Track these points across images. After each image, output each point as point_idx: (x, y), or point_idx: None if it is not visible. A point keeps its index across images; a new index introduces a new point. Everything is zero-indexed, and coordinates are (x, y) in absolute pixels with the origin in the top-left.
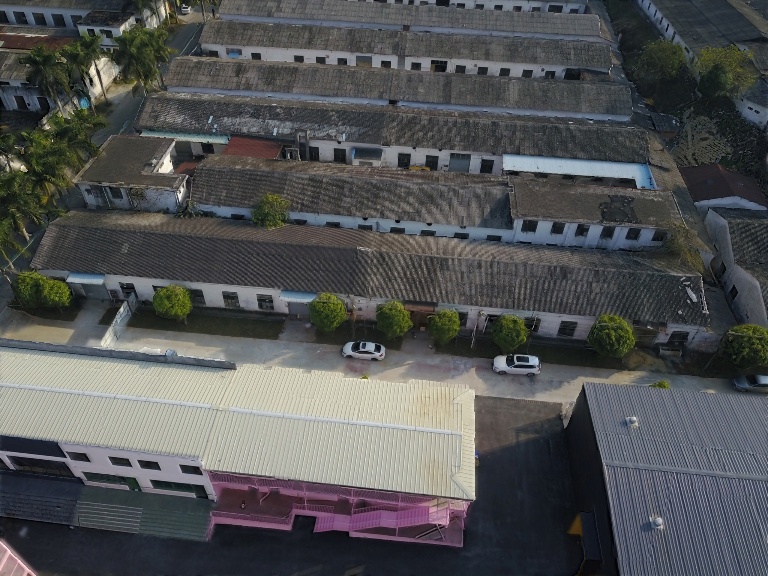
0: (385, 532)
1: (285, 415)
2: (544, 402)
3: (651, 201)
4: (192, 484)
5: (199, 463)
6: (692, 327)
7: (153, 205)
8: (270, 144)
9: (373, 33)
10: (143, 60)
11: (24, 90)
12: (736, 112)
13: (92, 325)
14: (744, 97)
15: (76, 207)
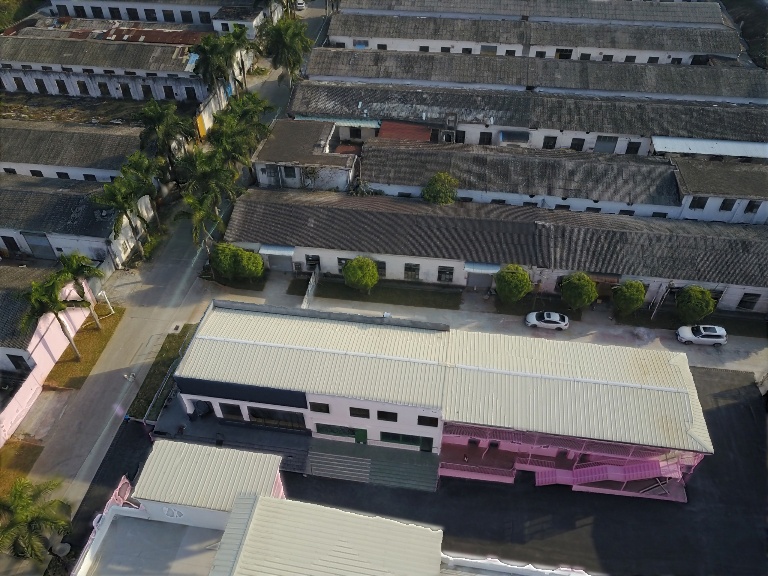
0: (610, 486)
1: (511, 372)
2: (735, 371)
3: None
4: (422, 436)
5: (440, 414)
6: None
7: (326, 183)
8: (420, 128)
9: (497, 23)
10: (295, 49)
11: (174, 80)
12: None
13: (281, 295)
14: None
15: (251, 186)
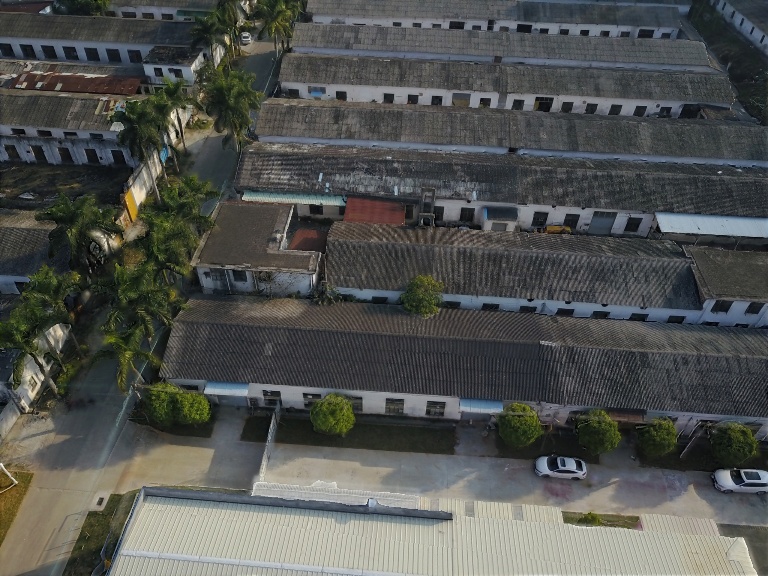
0: None
1: None
2: None
3: None
4: None
5: None
6: None
7: (284, 289)
8: (392, 205)
9: (469, 67)
10: (241, 111)
11: (97, 143)
12: None
13: (234, 442)
14: None
15: (193, 293)
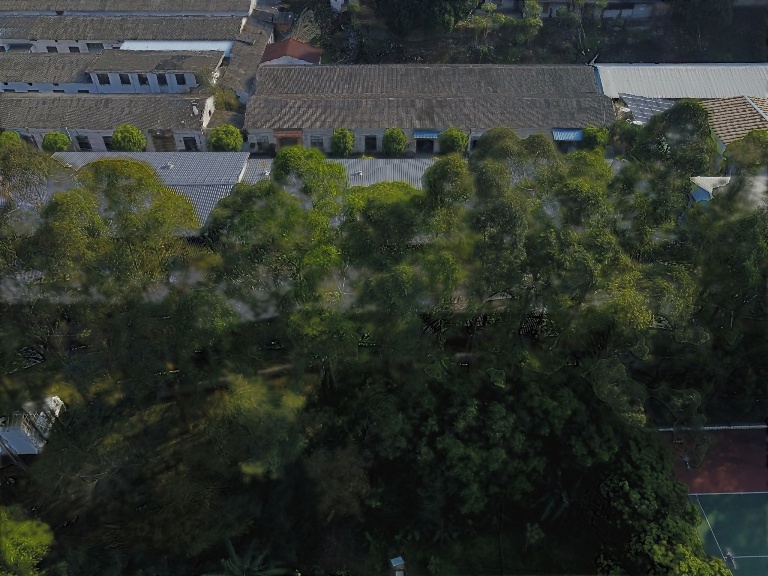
0: None
1: None
2: None
3: (203, 57)
4: None
5: None
6: (192, 132)
7: None
8: None
9: None
10: None
11: None
12: (328, 3)
13: None
14: None
15: None
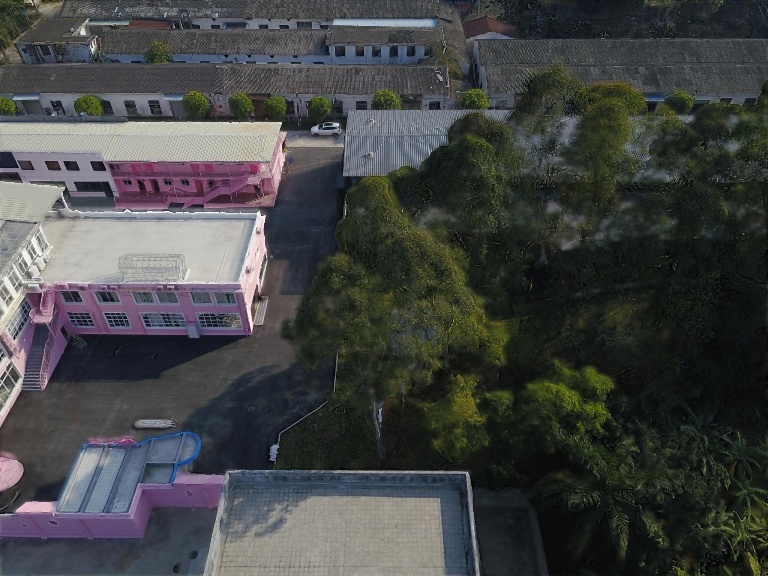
0: (225, 201)
1: (157, 135)
2: (341, 147)
3: (425, 32)
4: (101, 182)
5: (102, 157)
6: (439, 97)
7: (73, 56)
8: (162, 23)
9: None
10: None
11: None
12: None
13: None
14: None
15: None
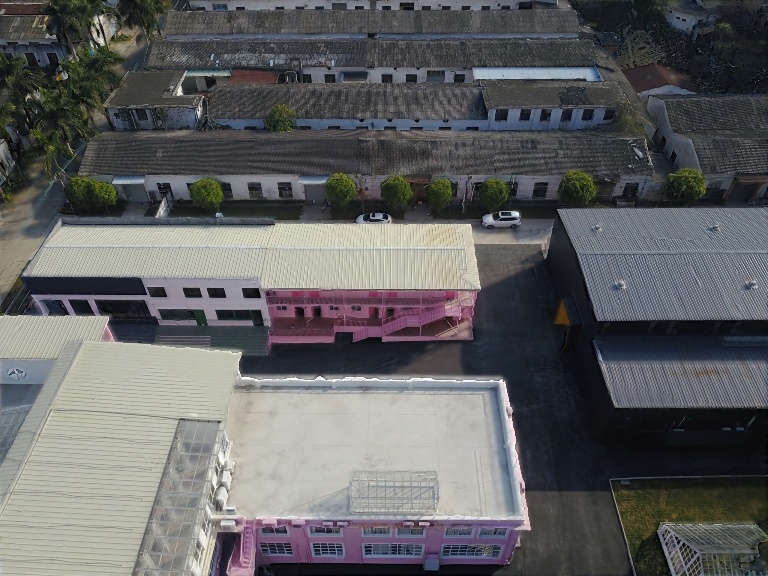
0: (411, 334)
1: (322, 248)
2: (527, 244)
3: (600, 89)
4: (251, 310)
5: (259, 284)
6: (641, 177)
7: (176, 122)
8: (268, 73)
9: None
10: (146, 8)
11: (34, 47)
12: (667, 23)
13: None
14: (672, 9)
15: None
